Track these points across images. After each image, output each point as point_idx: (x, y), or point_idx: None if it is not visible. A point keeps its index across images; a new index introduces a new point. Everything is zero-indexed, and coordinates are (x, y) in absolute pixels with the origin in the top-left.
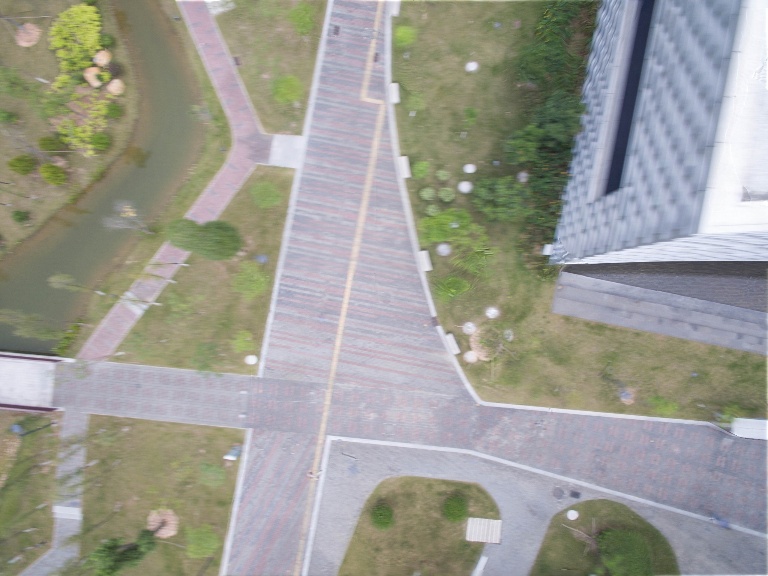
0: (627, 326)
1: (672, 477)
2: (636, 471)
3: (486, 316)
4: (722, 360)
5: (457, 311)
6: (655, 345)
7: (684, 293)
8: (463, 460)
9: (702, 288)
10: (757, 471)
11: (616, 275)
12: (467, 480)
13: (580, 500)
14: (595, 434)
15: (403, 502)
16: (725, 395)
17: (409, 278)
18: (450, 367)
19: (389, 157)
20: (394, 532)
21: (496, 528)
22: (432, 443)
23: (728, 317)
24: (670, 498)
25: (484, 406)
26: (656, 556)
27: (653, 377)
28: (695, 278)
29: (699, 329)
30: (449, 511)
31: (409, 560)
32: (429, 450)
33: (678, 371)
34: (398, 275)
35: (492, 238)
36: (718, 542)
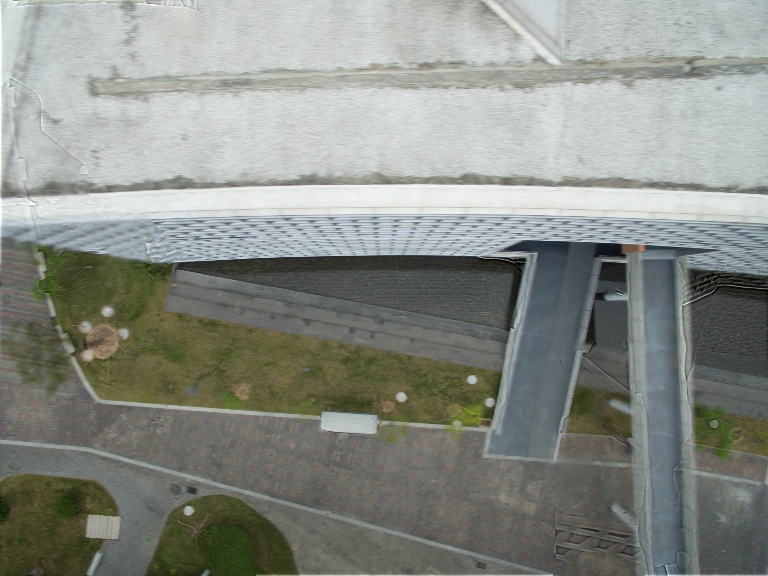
0: (240, 322)
1: (288, 472)
2: (252, 466)
3: (102, 315)
4: (335, 355)
5: (75, 311)
6: (268, 341)
7: (299, 289)
8: (81, 458)
9: (315, 283)
10: (373, 464)
11: (229, 272)
12: (85, 477)
13: (197, 496)
14: (211, 430)
15: (21, 500)
16: (339, 389)
17: (29, 279)
18: (69, 366)
19: (9, 160)
20: (12, 530)
21: (115, 525)
22: (51, 441)
23: (342, 312)
24: (286, 492)
25: (102, 404)
26: (271, 550)
27: (267, 373)
28: (307, 274)
29: (311, 324)
30: (66, 508)
31: (27, 557)
32: (48, 448)
33: (292, 366)
34: (18, 276)
35: (107, 238)
36: (334, 536)
